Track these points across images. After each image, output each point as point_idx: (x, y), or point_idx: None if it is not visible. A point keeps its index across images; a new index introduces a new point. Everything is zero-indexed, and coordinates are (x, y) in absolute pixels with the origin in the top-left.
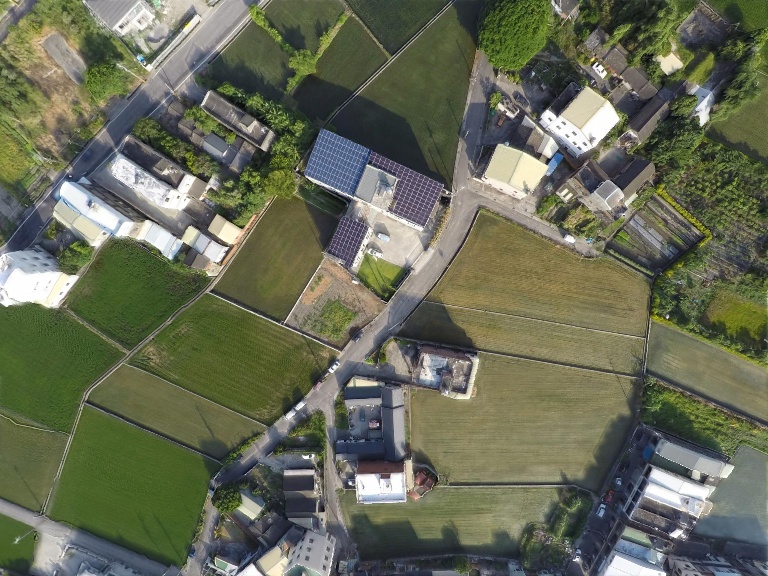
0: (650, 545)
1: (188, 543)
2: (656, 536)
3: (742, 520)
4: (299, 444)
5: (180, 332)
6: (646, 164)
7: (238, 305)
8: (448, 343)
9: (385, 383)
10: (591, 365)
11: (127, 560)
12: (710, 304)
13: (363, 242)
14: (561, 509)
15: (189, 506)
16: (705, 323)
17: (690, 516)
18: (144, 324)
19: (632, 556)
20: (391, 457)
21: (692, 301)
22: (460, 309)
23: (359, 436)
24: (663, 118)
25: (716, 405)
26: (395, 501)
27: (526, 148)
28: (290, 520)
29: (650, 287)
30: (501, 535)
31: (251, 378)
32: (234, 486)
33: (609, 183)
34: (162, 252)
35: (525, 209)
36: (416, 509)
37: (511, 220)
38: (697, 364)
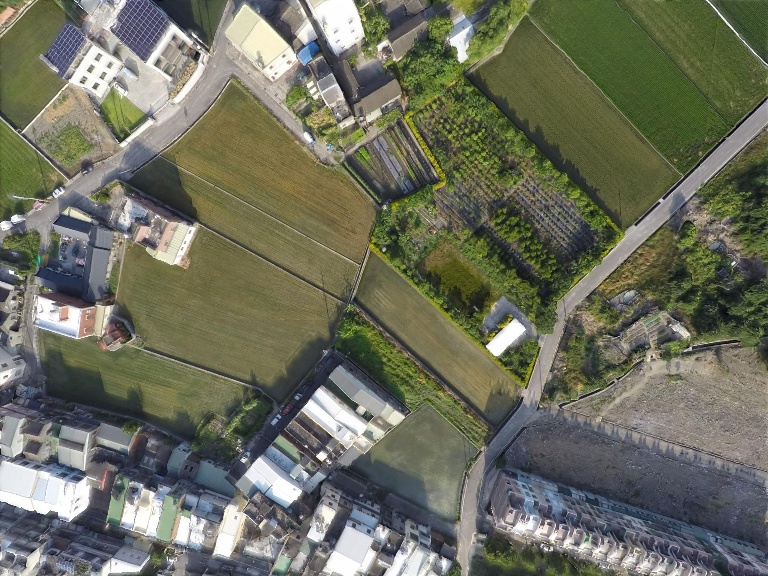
0: (299, 461)
1: None
2: (305, 454)
3: (409, 477)
4: (11, 259)
5: None
6: (390, 79)
7: None
8: (173, 206)
9: (100, 223)
10: (303, 275)
11: None
12: (431, 253)
13: (87, 60)
14: (242, 407)
15: None
16: (421, 270)
17: (341, 446)
18: None
19: (279, 466)
20: (85, 297)
21: (415, 244)
22: (192, 175)
23: (69, 271)
24: (421, 38)
25: (411, 355)
26: (67, 334)
27: (280, 24)
28: None
29: (377, 215)
30: (182, 414)
31: None
32: None
33: (331, 76)
34: None
35: (276, 93)
36: (108, 362)
37: (259, 100)
38: (405, 309)
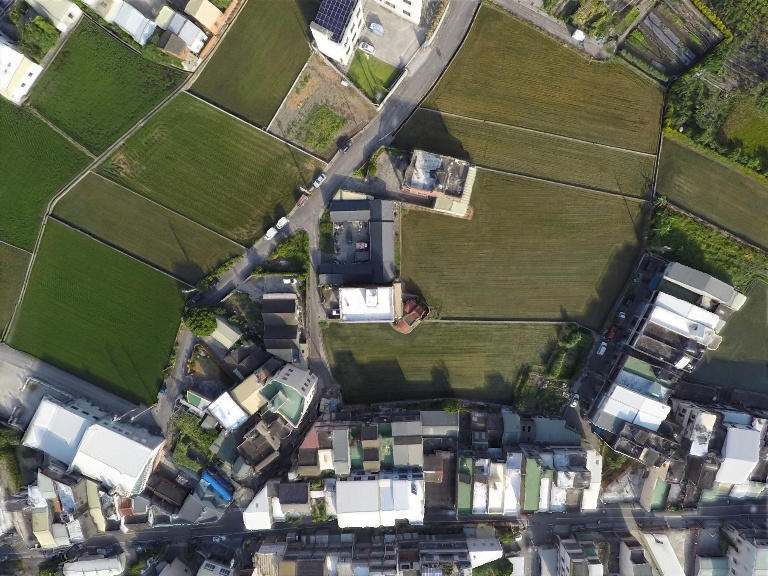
0: (654, 379)
1: (159, 380)
2: (661, 367)
3: (751, 366)
4: (280, 269)
5: (153, 138)
6: None
7: (216, 106)
8: None
9: (374, 198)
10: (597, 186)
11: (93, 397)
12: (727, 119)
13: (353, 16)
14: (559, 349)
15: (161, 337)
16: (721, 140)
17: (698, 346)
18: (114, 127)
19: (634, 391)
20: (379, 279)
21: (708, 115)
22: (457, 118)
23: (345, 261)
24: None
25: (729, 233)
26: (382, 320)
27: None
28: (269, 351)
29: (663, 96)
30: (495, 378)
31: (230, 193)
32: (208, 307)
33: None
34: (133, 37)
35: (531, 3)
36: (404, 346)
37: (516, 14)
38: (710, 188)
